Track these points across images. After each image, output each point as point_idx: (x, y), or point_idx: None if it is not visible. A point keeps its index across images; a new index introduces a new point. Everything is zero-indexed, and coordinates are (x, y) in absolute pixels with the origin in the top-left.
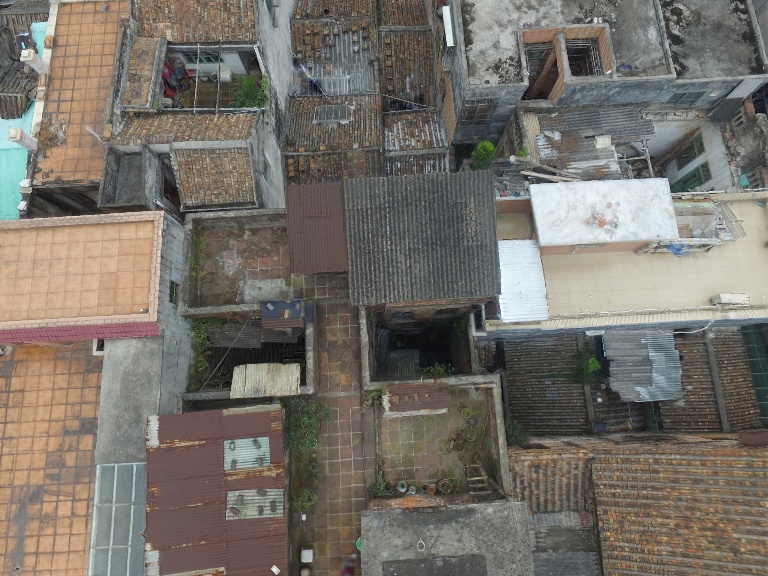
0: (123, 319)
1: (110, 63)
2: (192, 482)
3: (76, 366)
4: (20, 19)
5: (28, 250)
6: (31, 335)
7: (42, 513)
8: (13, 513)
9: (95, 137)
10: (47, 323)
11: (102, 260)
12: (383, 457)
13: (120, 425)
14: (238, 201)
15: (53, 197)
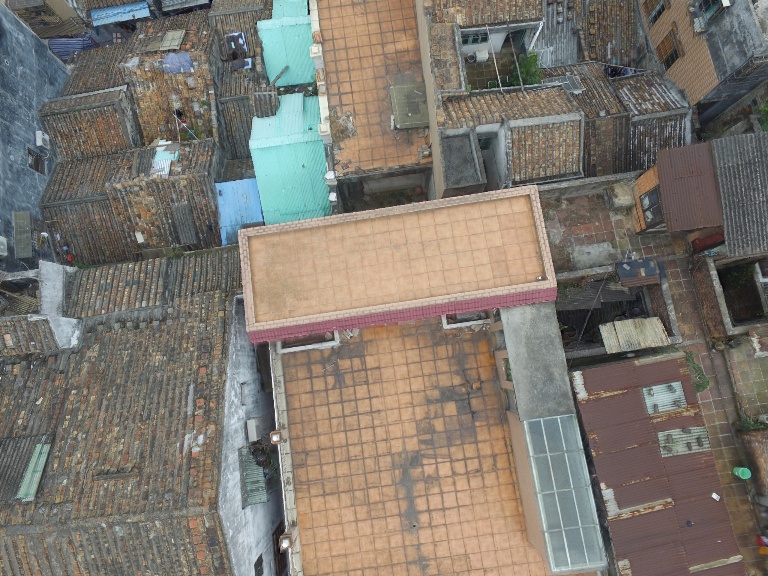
0: (526, 287)
1: (380, 52)
2: (624, 427)
3: (423, 341)
4: (228, 19)
5: (414, 233)
6: (440, 310)
7: (425, 475)
8: (398, 477)
9: (383, 125)
10: (456, 297)
11: (486, 236)
12: (740, 396)
13: (536, 384)
14: (563, 172)
15: (342, 187)
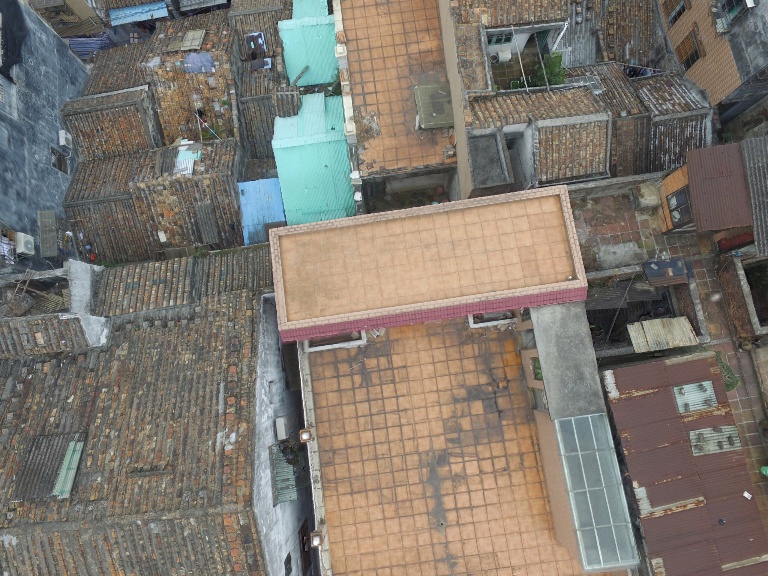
0: (557, 287)
1: (404, 53)
2: (656, 426)
3: (450, 340)
4: (248, 19)
5: (444, 232)
6: (471, 309)
7: (452, 474)
8: (425, 476)
9: (407, 125)
10: (487, 297)
11: (516, 235)
12: (767, 395)
13: (566, 383)
14: (590, 172)
15: (365, 187)
